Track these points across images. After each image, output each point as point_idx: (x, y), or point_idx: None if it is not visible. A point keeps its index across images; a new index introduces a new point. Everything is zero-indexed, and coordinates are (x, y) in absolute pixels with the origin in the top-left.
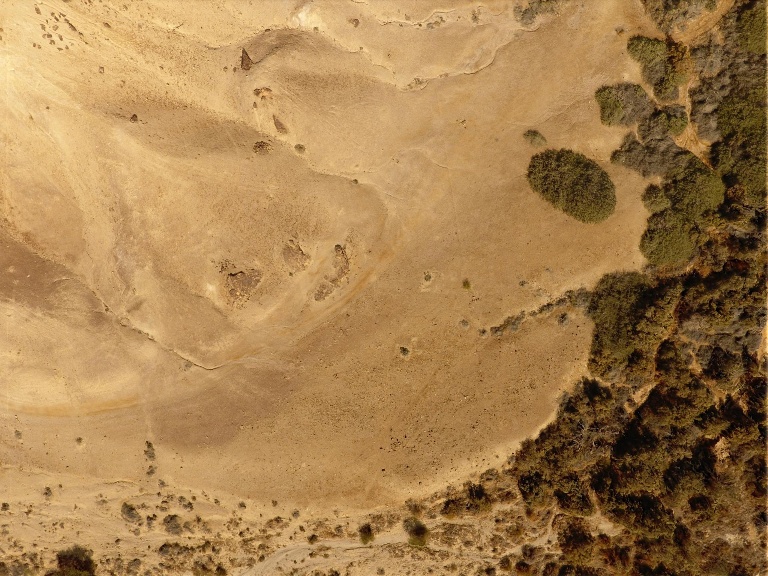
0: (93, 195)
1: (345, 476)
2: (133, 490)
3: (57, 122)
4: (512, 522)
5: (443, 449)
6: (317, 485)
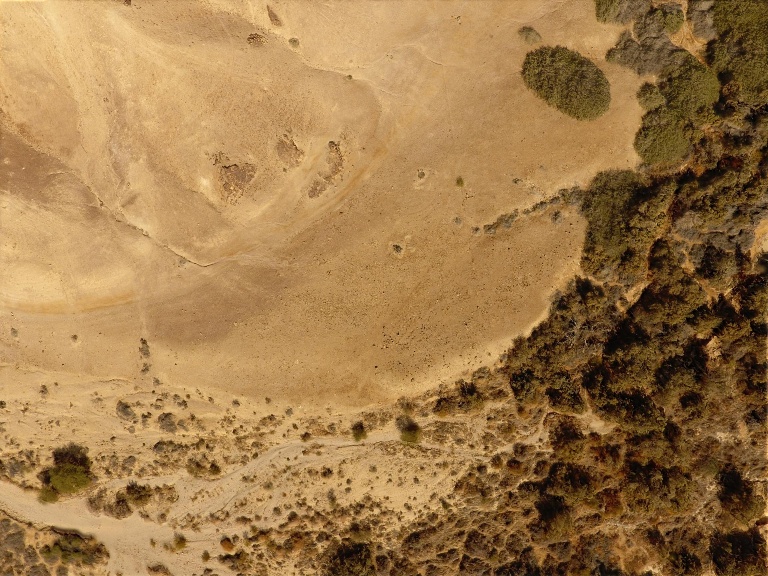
0: (87, 84)
1: (338, 373)
2: (128, 388)
3: (51, 2)
4: (504, 420)
5: (435, 346)
6: (310, 382)
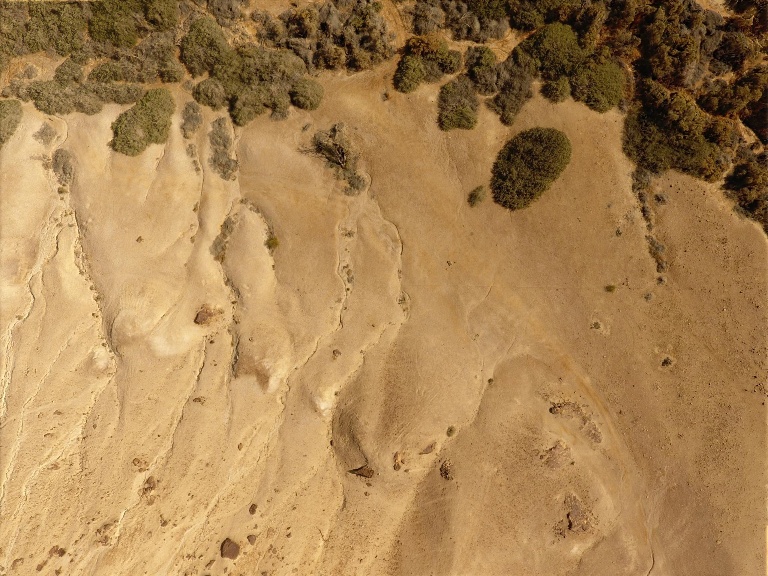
0: None
1: None
2: None
3: None
4: None
5: None
6: None
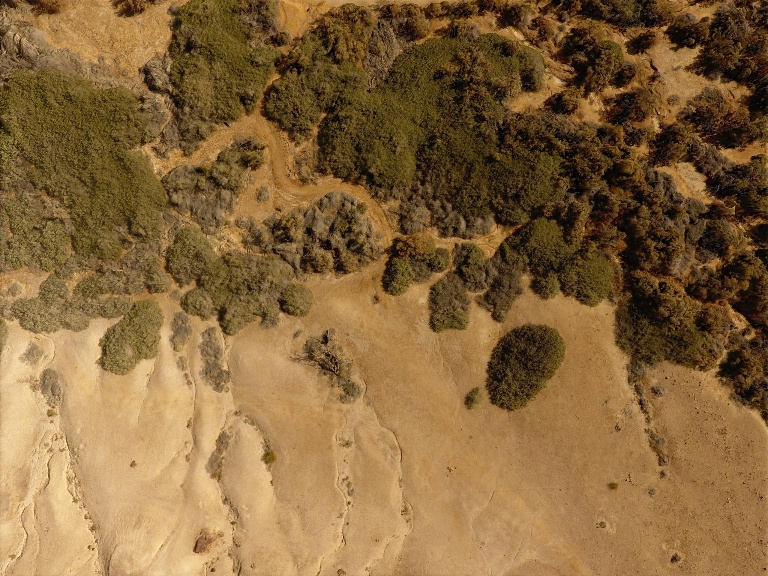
0: None
1: None
2: None
3: None
4: None
5: None
6: None
